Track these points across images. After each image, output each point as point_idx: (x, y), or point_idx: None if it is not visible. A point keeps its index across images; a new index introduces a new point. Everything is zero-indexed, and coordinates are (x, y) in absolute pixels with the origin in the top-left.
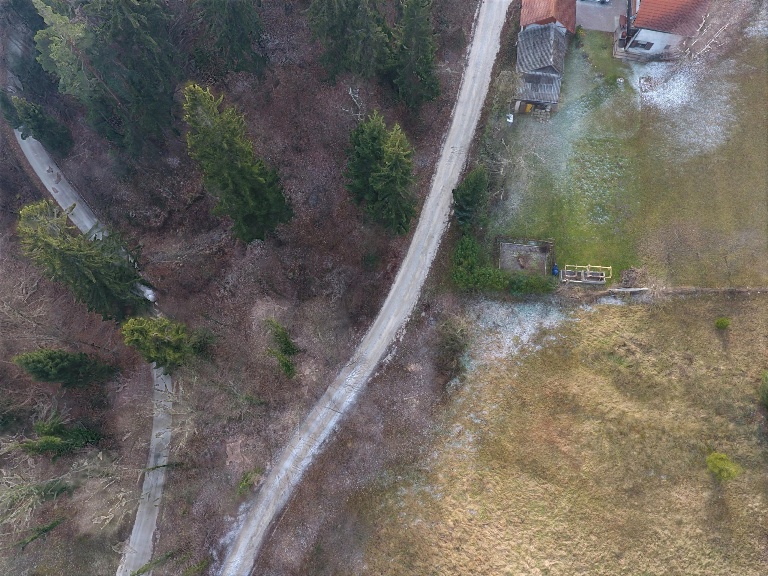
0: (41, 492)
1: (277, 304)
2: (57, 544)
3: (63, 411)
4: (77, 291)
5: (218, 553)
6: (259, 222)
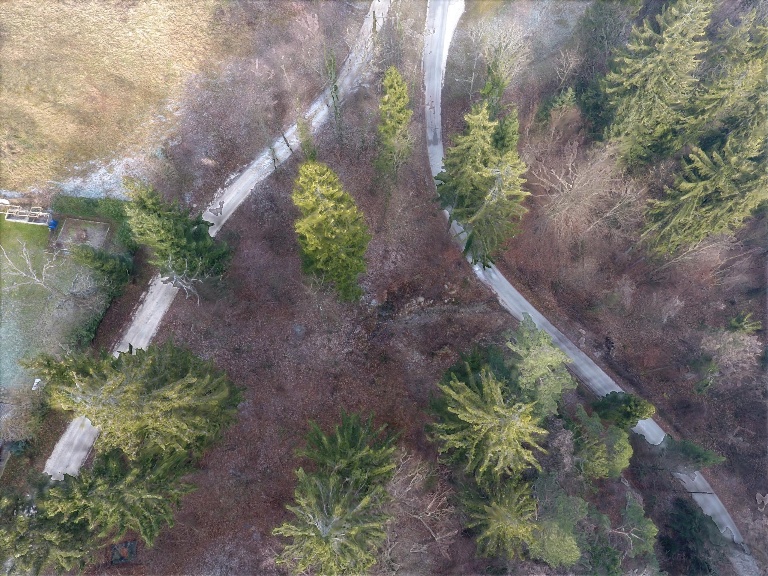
0: None
1: None
2: None
3: None
4: None
5: None
6: None
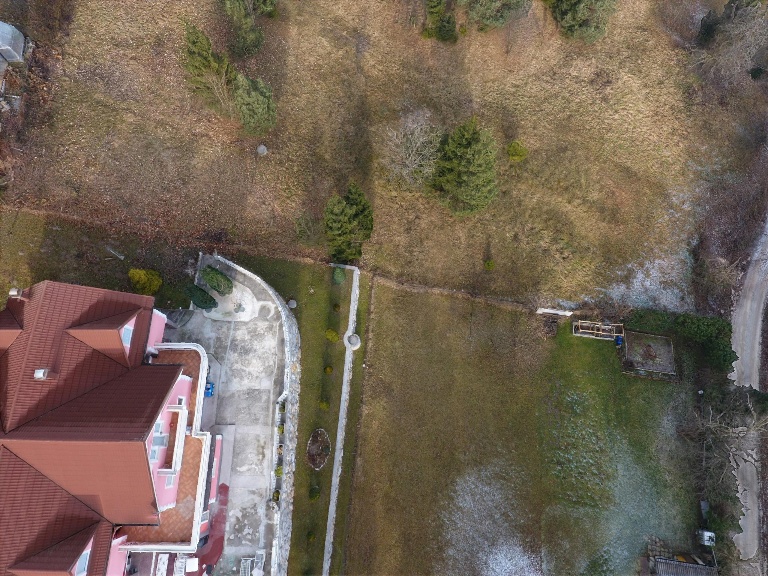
0: None
1: None
2: None
3: None
4: None
5: None
6: None
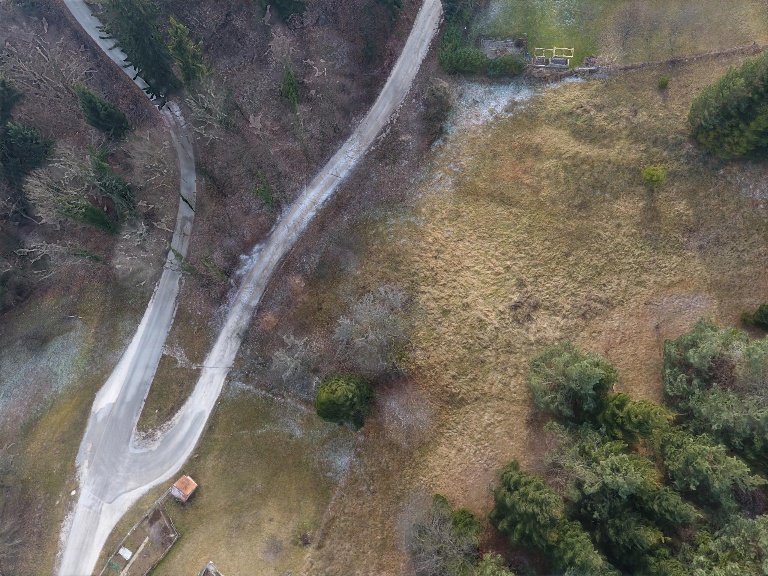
0: (91, 208)
1: (289, 106)
2: (97, 288)
3: (111, 143)
4: (128, 26)
5: (235, 281)
6: (277, 0)
